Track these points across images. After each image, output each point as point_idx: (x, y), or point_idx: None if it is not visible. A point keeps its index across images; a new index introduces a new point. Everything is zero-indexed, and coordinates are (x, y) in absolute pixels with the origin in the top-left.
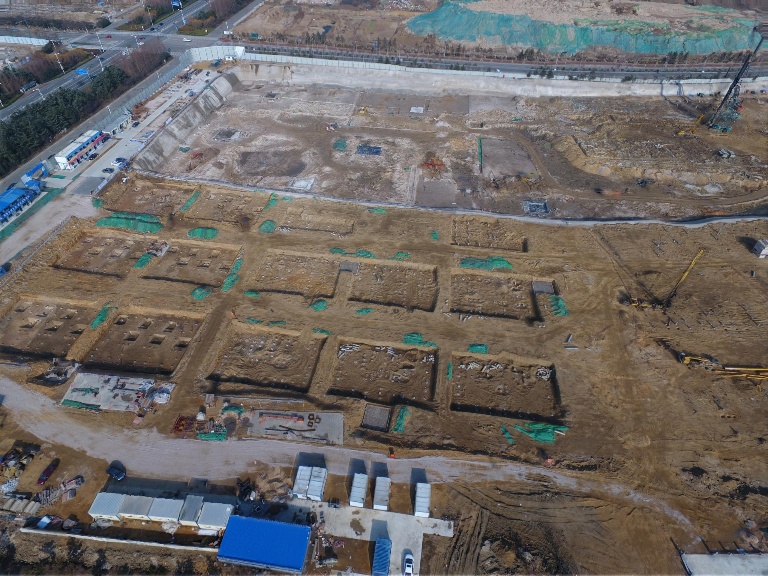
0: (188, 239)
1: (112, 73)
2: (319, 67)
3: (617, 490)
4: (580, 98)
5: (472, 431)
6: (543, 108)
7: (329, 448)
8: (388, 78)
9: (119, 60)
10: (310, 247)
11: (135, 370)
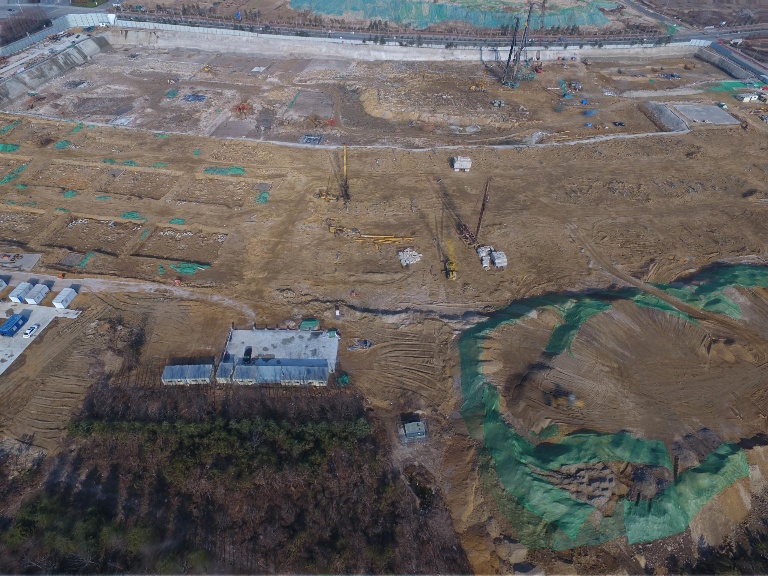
0: None
1: None
2: (182, 33)
3: (216, 298)
4: (407, 62)
5: (136, 267)
6: (370, 69)
7: (18, 272)
8: (241, 43)
9: None
10: (88, 158)
11: None
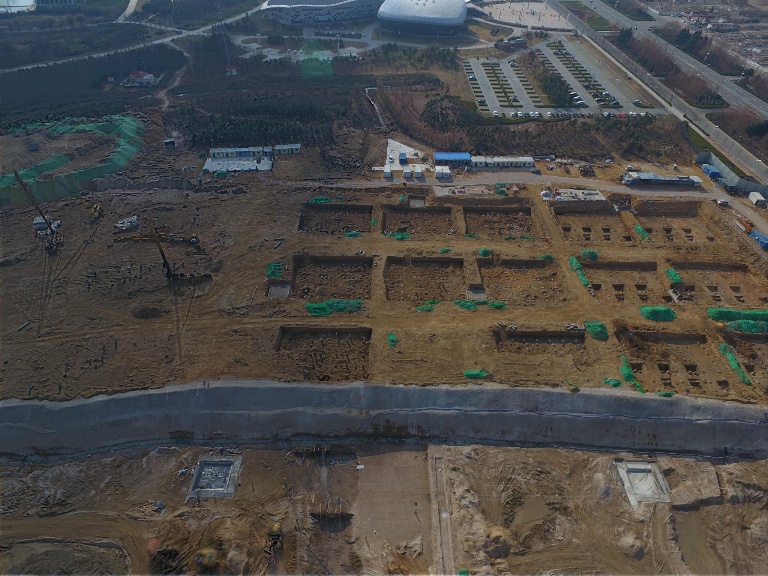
0: (664, 305)
1: None
2: None
3: (288, 183)
4: None
5: (360, 198)
6: None
7: (439, 184)
8: None
9: None
10: (529, 307)
11: (580, 213)
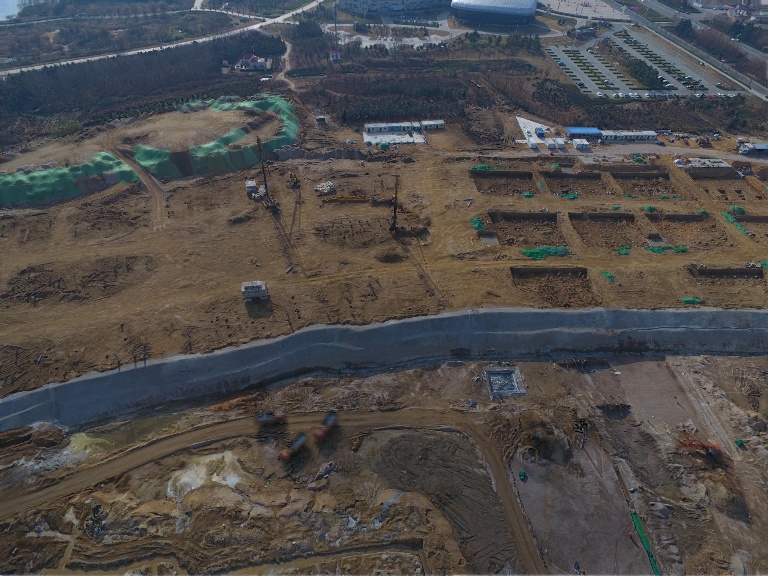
0: None
1: None
2: None
3: None
4: None
5: (518, 166)
6: None
7: (581, 154)
8: None
9: None
10: (708, 251)
11: (711, 178)
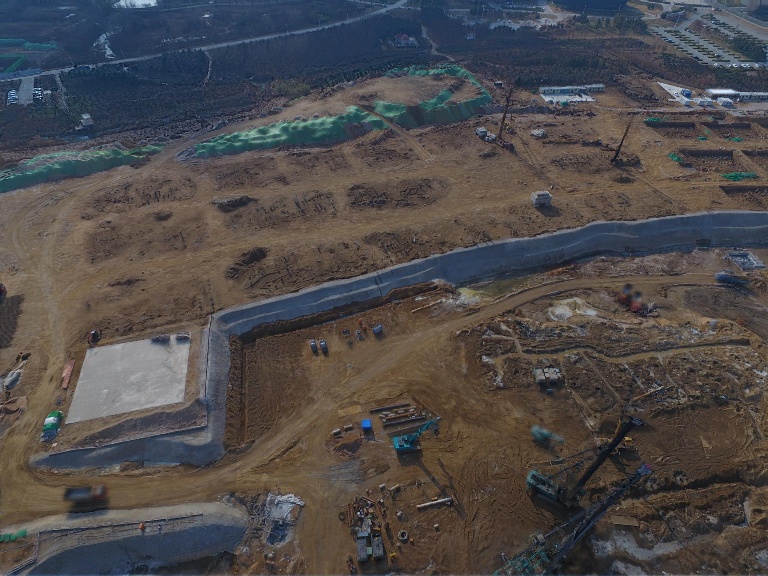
0: None
1: None
2: None
3: (620, 109)
4: None
5: (681, 118)
6: None
7: None
8: None
9: None
10: None
11: None
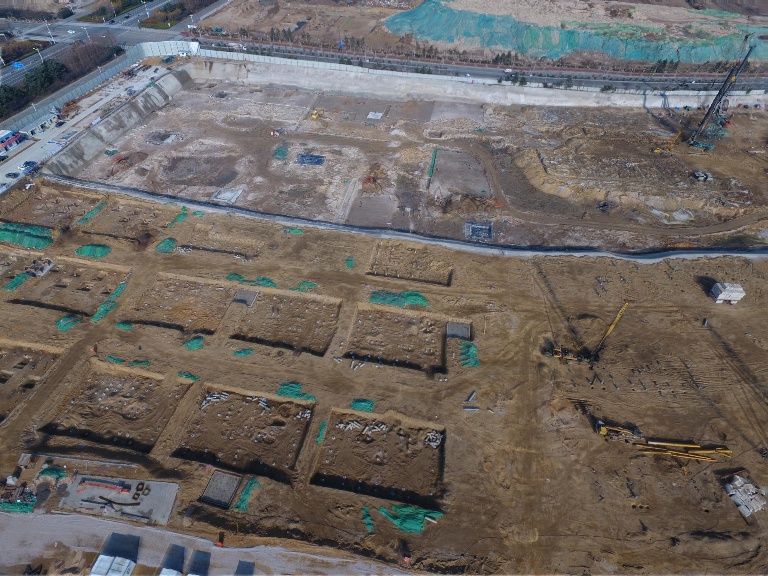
0: (75, 257)
1: (49, 67)
2: (277, 66)
3: None
4: (554, 108)
5: (327, 513)
6: (512, 118)
7: (149, 529)
8: (349, 80)
9: (67, 53)
10: (206, 272)
11: None
